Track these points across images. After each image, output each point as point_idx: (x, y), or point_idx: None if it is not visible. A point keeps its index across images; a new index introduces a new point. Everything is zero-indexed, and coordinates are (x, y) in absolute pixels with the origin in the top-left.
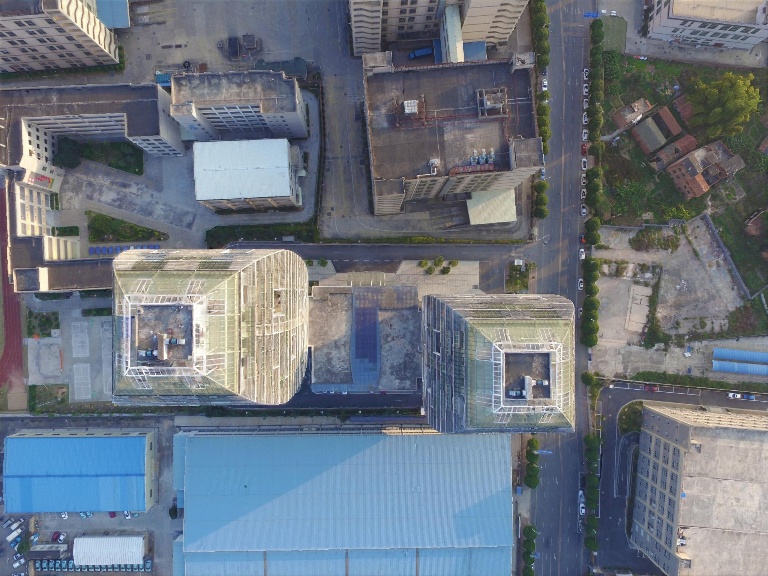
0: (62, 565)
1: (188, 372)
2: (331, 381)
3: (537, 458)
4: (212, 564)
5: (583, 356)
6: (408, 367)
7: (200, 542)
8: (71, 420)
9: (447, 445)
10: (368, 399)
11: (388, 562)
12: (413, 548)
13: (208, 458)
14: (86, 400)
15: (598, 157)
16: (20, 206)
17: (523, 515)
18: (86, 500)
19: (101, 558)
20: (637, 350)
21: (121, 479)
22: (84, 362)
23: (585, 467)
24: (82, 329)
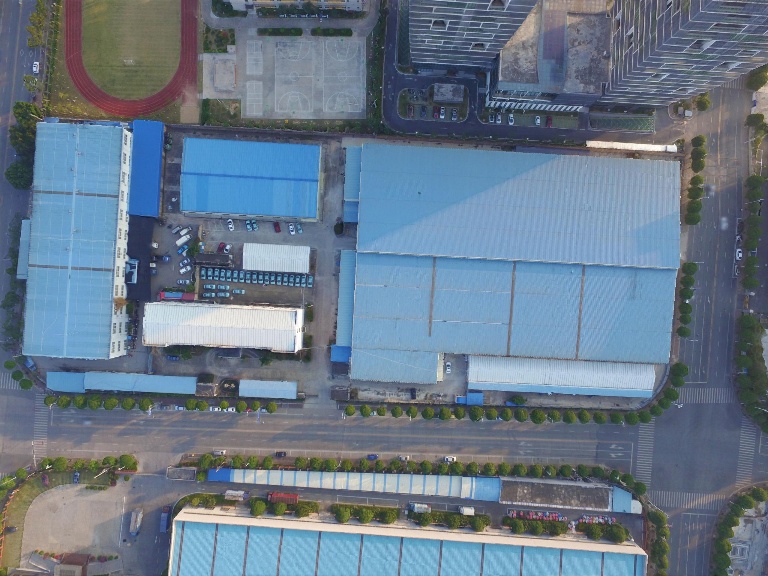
0: (227, 274)
1: None
2: (517, 81)
3: (702, 191)
4: (382, 268)
5: (746, 104)
6: (593, 72)
7: (374, 242)
8: (241, 135)
9: (617, 168)
10: (533, 132)
11: (554, 278)
12: (580, 265)
13: (383, 164)
14: (257, 117)
15: None
16: None
17: (680, 257)
18: (260, 202)
19: (269, 263)
20: None
21: (295, 183)
22: (257, 80)
23: (743, 213)
24: (257, 47)
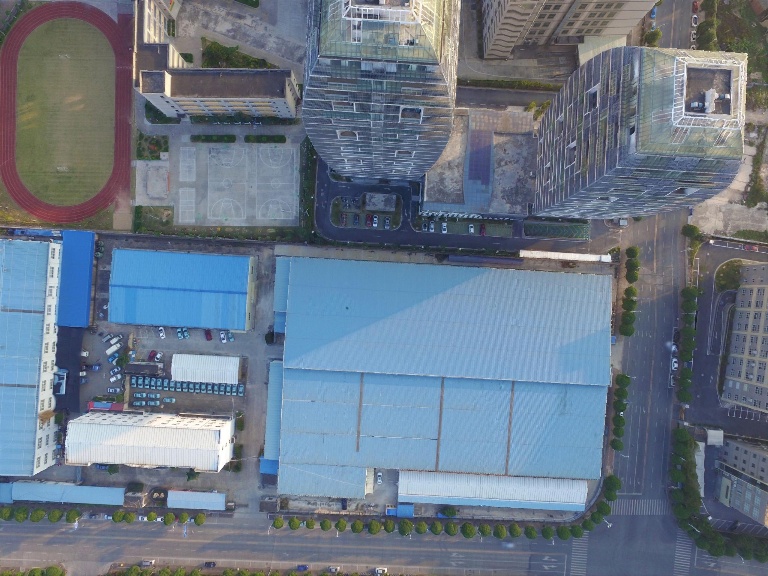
0: (157, 383)
1: (405, 17)
2: (443, 201)
3: (635, 304)
4: (309, 383)
5: (683, 212)
6: (520, 192)
7: (300, 359)
8: (174, 242)
9: (548, 282)
10: (467, 240)
11: (483, 394)
12: (509, 381)
13: (311, 278)
14: (190, 224)
15: (709, 14)
16: (147, 15)
17: (615, 366)
18: (188, 315)
19: (198, 375)
20: (738, 208)
21: (224, 296)
22: (190, 186)
23: (680, 322)
24: (190, 154)
